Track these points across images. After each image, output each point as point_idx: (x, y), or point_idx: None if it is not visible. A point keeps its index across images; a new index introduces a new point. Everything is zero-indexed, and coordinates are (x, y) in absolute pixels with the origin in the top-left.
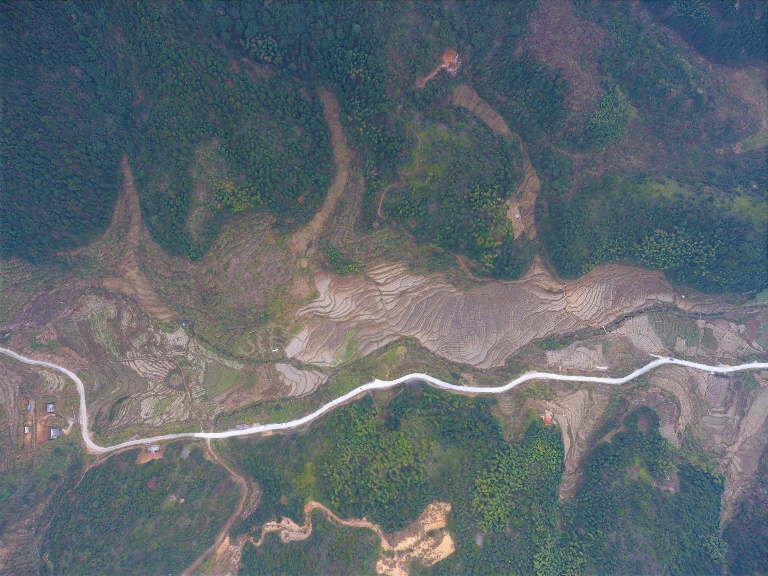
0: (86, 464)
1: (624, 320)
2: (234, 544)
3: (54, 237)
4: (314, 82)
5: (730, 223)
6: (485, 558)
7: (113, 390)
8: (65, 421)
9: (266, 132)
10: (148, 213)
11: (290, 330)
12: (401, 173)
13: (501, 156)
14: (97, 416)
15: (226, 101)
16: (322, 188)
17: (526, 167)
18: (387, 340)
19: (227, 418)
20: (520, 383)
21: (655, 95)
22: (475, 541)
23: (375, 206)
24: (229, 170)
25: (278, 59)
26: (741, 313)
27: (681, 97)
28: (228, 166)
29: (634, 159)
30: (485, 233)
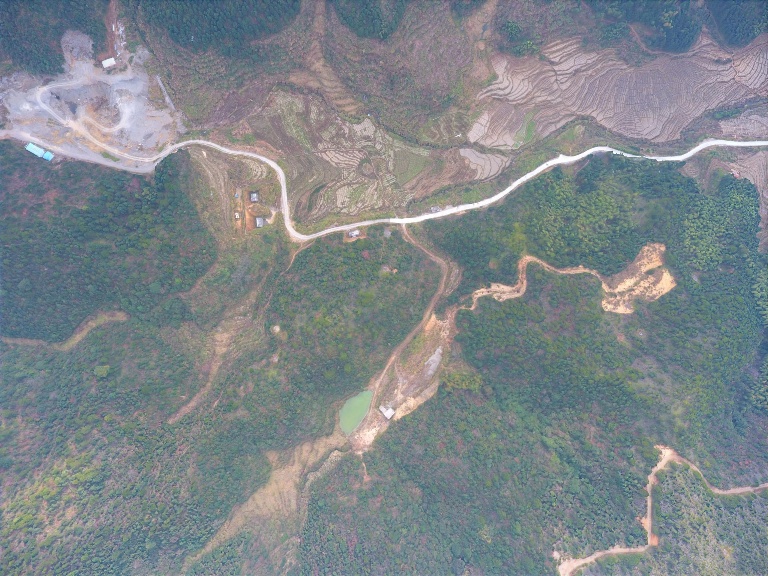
0: (292, 251)
1: None
2: (442, 318)
3: (251, 21)
4: None
5: None
6: (707, 289)
7: (310, 179)
8: (269, 210)
9: None
10: None
11: (471, 115)
12: None
13: None
14: (297, 206)
15: None
16: None
17: None
18: (564, 121)
19: (419, 204)
20: (700, 150)
21: None
22: (692, 278)
23: None
24: None
25: None
26: None
27: None
28: None
29: None
30: None
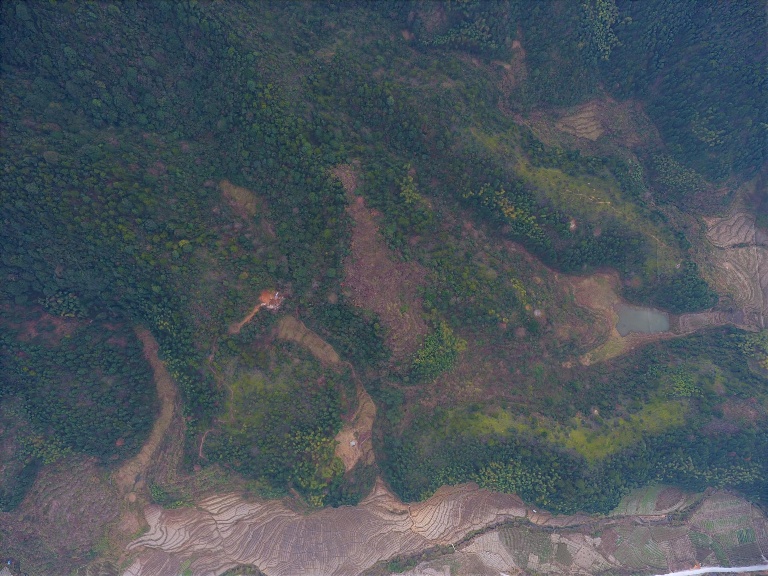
0: None
1: (474, 537)
2: None
3: None
4: (130, 323)
5: (565, 459)
6: None
7: None
8: None
9: (67, 393)
10: None
11: (121, 564)
12: (217, 420)
13: (325, 395)
14: None
15: (20, 369)
16: (143, 428)
17: (360, 393)
18: (224, 568)
19: None
20: None
21: (488, 323)
22: None
23: (195, 449)
24: None
25: (82, 313)
26: (597, 525)
27: (515, 325)
28: None
29: (470, 385)
30: (308, 477)
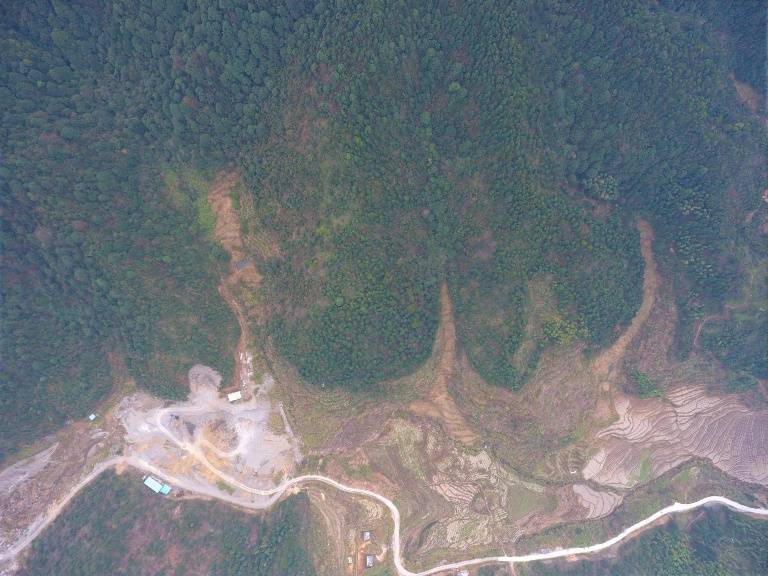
0: None
1: None
2: None
3: (385, 370)
4: (633, 212)
5: None
6: None
7: (424, 516)
8: (380, 548)
9: (607, 271)
10: (470, 343)
11: (588, 452)
12: (726, 306)
13: None
14: (407, 542)
15: (577, 244)
16: None
17: None
18: (679, 460)
19: (528, 541)
20: None
21: None
22: None
23: (693, 336)
24: (558, 304)
25: (614, 196)
26: None
27: None
28: (555, 299)
29: None
30: None
